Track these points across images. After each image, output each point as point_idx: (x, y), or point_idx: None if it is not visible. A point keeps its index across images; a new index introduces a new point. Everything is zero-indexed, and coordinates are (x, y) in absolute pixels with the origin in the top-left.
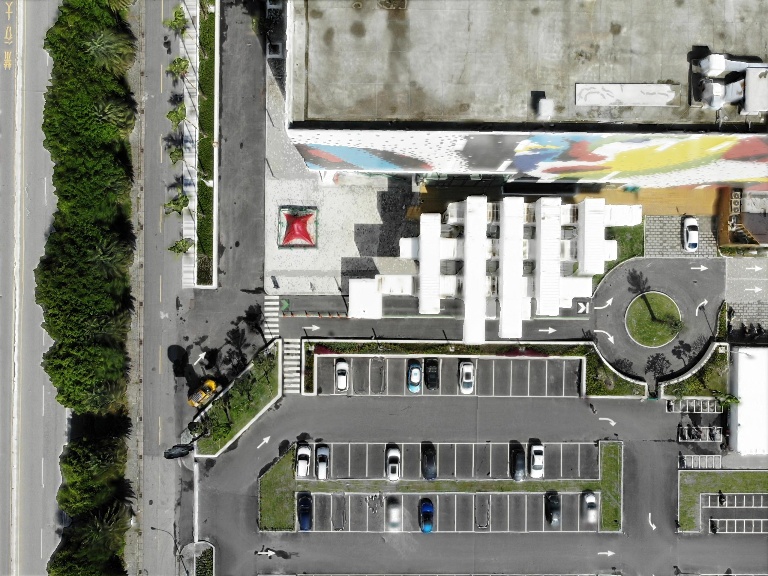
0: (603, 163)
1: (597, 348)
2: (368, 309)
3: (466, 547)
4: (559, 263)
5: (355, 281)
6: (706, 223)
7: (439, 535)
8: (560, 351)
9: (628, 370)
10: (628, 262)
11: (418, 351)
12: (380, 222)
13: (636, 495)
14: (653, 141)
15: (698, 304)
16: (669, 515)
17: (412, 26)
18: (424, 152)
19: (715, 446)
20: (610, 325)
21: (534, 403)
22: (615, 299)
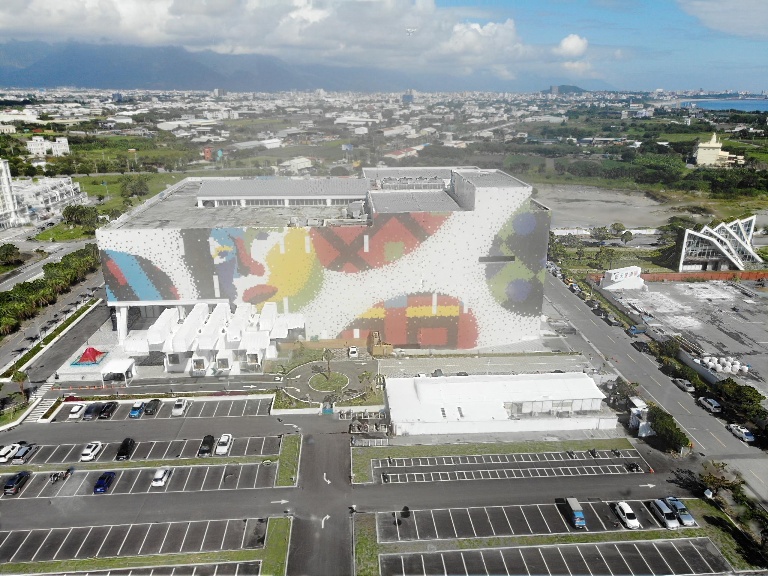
0: (269, 280)
1: None
2: (117, 368)
3: (135, 504)
4: (244, 317)
5: (115, 359)
6: (364, 350)
7: (111, 497)
8: None
9: None
10: (313, 363)
11: (147, 397)
12: (148, 355)
13: (312, 463)
14: (271, 237)
15: None
16: (343, 474)
17: (170, 223)
18: (167, 261)
19: (382, 434)
20: None
21: None
22: (302, 375)
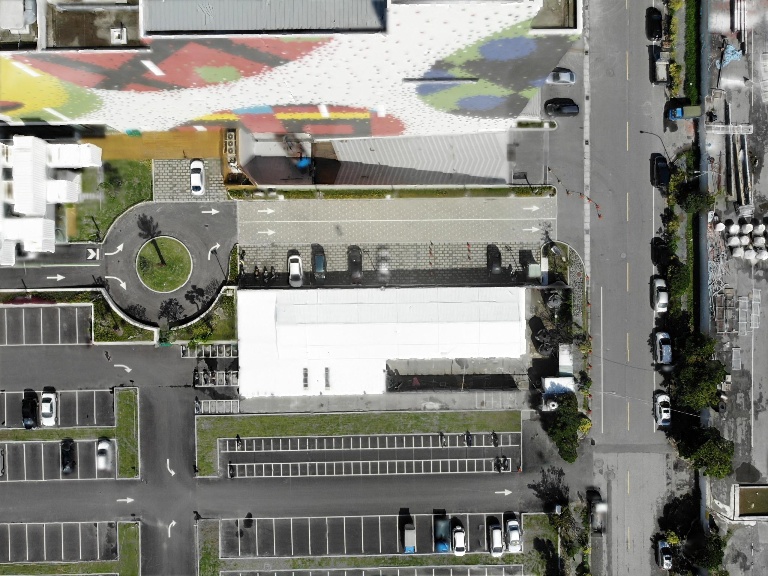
0: None
1: (108, 294)
2: None
3: None
4: None
5: None
6: (216, 166)
7: None
8: (66, 298)
9: (141, 316)
10: (138, 207)
11: None
12: None
13: (154, 441)
14: None
15: (210, 248)
16: (187, 461)
17: None
18: None
19: (232, 391)
20: (121, 271)
21: (48, 351)
22: (126, 245)
